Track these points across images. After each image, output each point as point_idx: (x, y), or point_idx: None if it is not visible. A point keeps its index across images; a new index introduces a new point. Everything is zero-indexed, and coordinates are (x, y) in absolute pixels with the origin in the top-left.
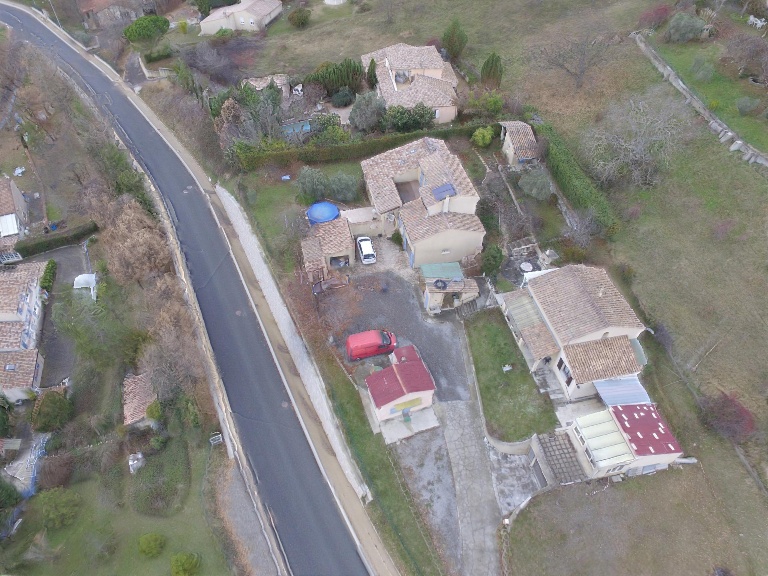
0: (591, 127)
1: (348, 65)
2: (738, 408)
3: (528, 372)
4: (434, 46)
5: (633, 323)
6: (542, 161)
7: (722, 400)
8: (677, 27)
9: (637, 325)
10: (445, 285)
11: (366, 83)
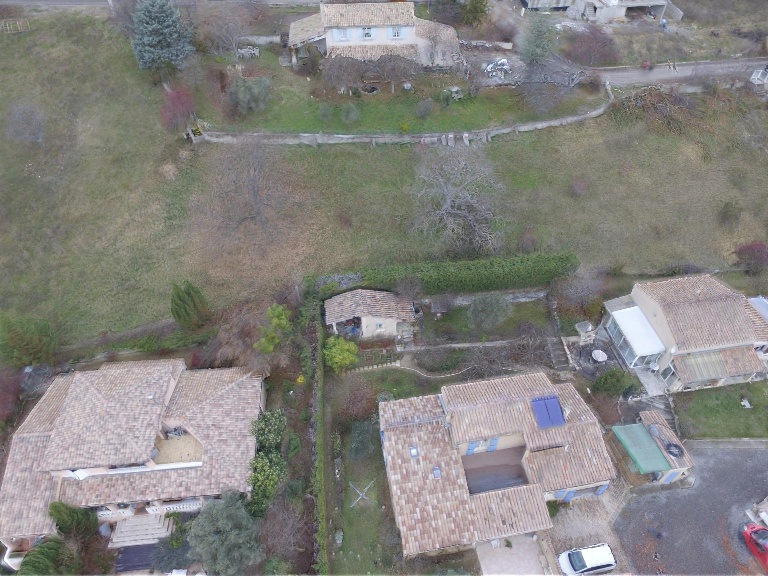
0: (356, 234)
1: (38, 571)
2: (754, 248)
3: (750, 385)
4: (78, 373)
5: (710, 281)
6: (415, 297)
7: (747, 255)
8: (251, 98)
9: (709, 279)
10: (673, 445)
11: (75, 539)
